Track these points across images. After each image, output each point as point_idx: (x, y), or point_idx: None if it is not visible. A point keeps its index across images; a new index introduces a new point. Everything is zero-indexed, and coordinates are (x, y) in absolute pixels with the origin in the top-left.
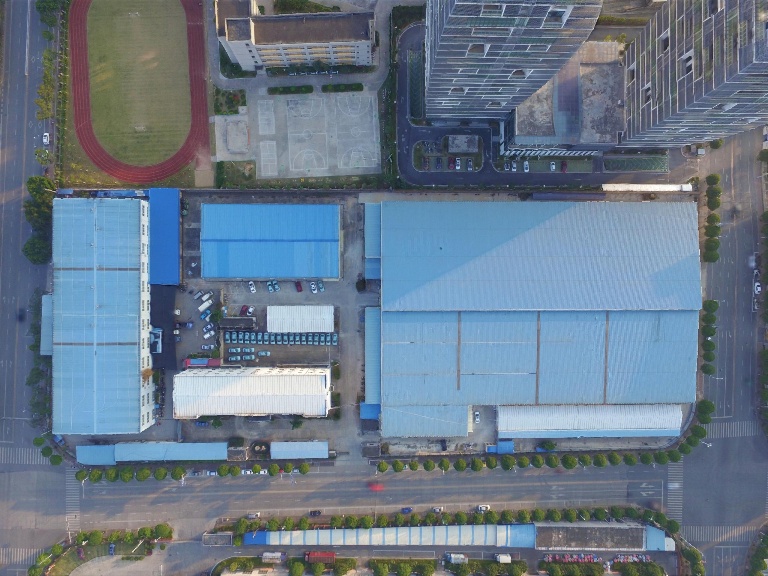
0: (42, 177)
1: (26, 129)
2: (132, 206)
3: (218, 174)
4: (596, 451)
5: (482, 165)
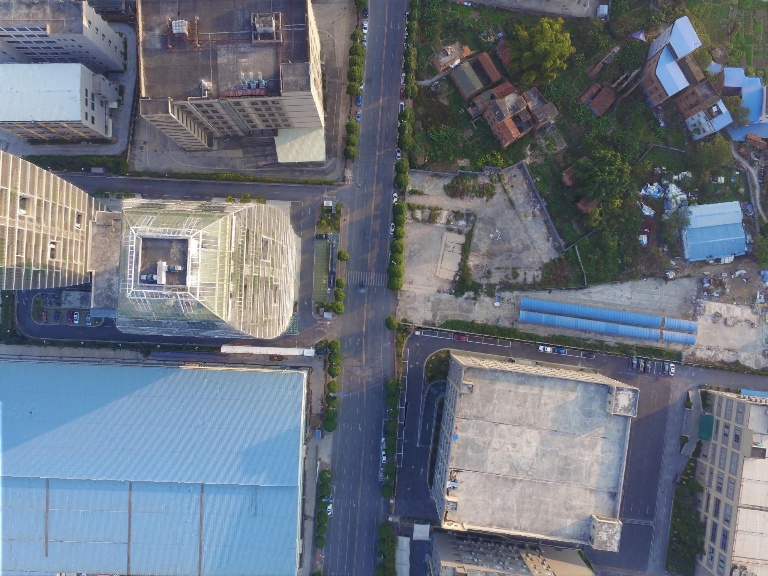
0: None
1: None
2: None
3: None
4: None
5: (103, 320)
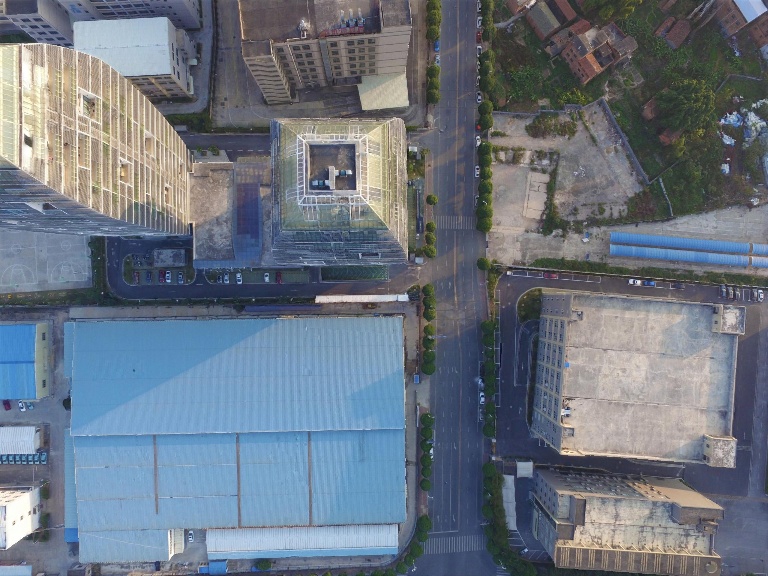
0: None
1: None
2: None
3: None
4: (314, 570)
5: (195, 277)
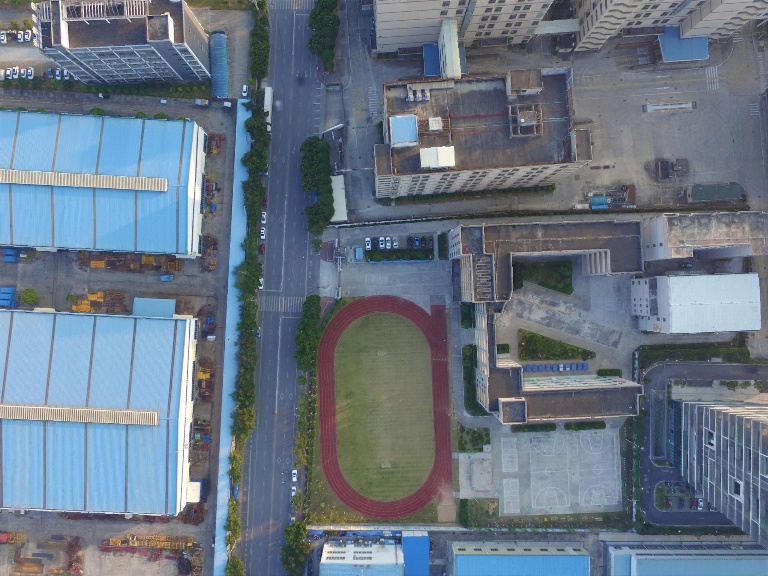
0: (297, 523)
1: (274, 465)
2: (396, 570)
3: (462, 512)
4: None
5: None
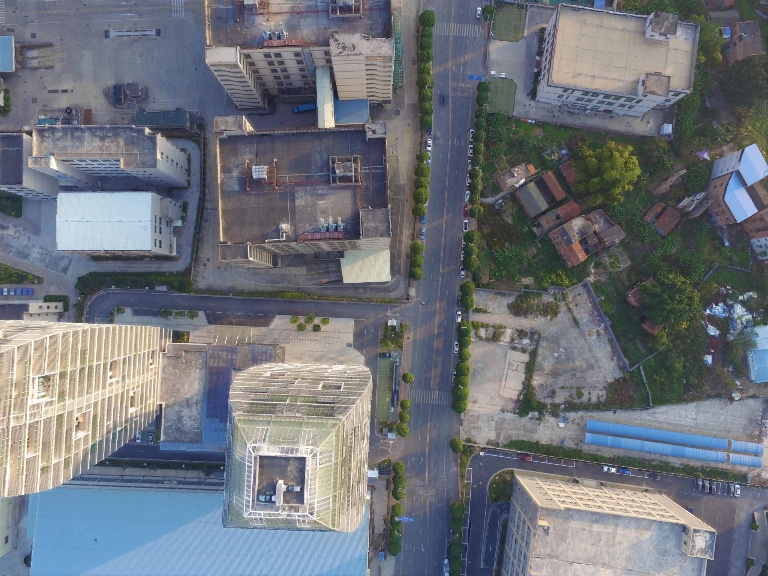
0: None
1: None
2: None
3: None
4: None
5: None
